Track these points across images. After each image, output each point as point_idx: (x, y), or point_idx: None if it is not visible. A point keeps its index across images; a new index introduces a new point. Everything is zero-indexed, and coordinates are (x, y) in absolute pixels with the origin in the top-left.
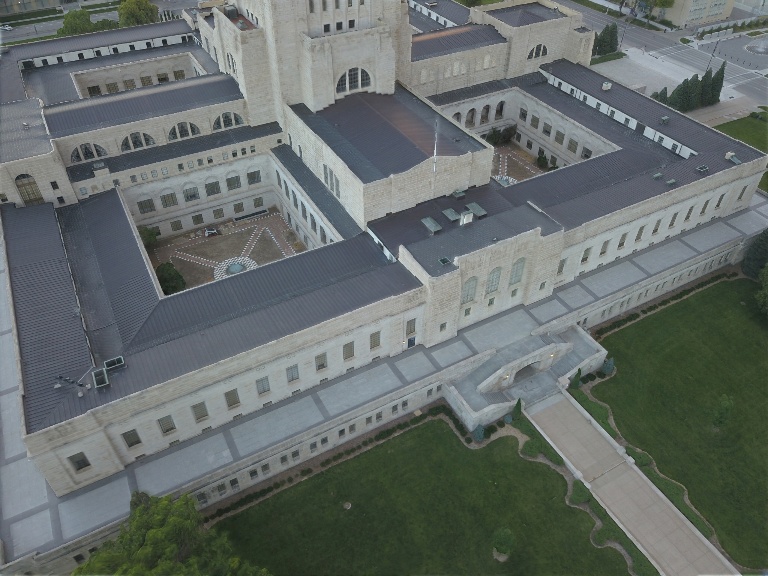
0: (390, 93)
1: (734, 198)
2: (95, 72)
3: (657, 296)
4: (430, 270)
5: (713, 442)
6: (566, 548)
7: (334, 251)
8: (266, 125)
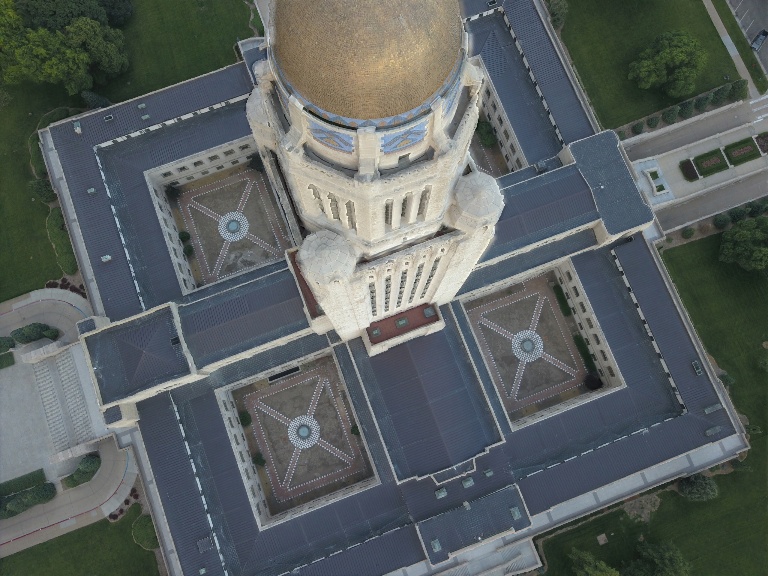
0: None
1: None
2: (604, 393)
3: None
4: None
5: (208, 2)
6: None
7: None
8: None
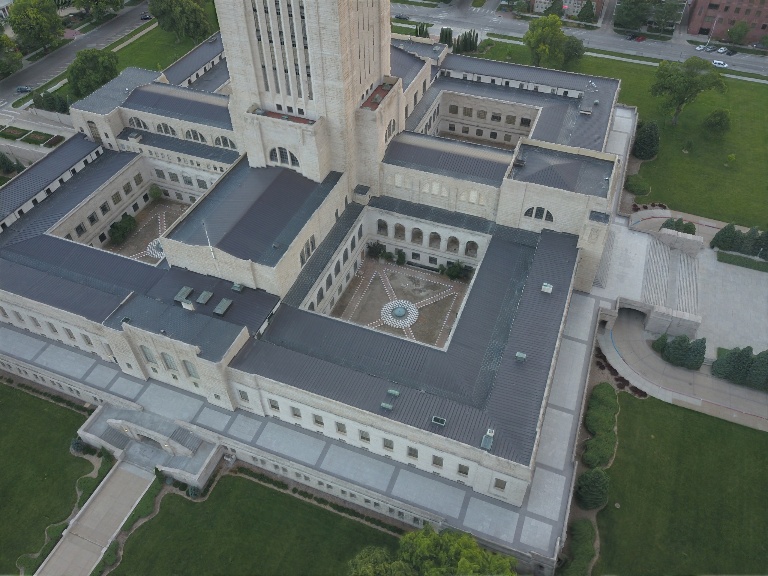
0: (316, 181)
1: (483, 480)
2: None
3: (326, 491)
4: (111, 319)
5: None
6: (7, 544)
7: (141, 270)
8: None
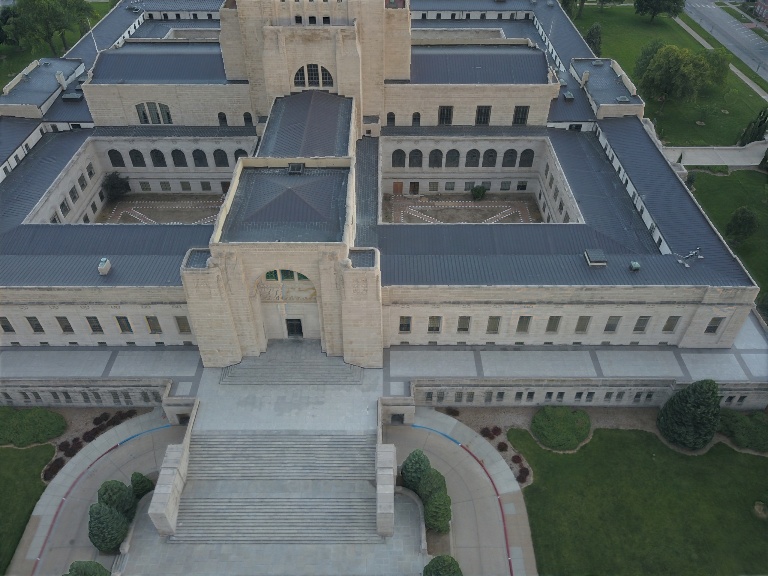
0: None
1: None
2: None
3: None
4: (49, 60)
5: None
6: None
7: None
8: None
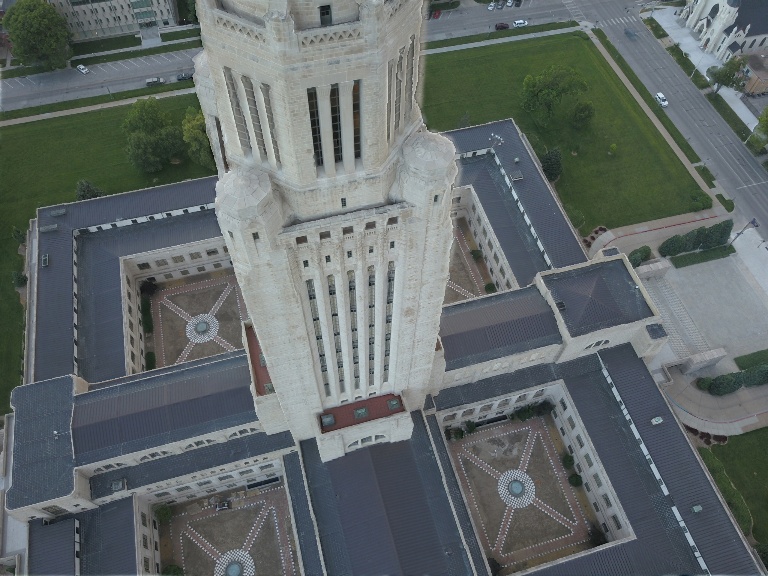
0: (406, 439)
1: None
2: (144, 256)
3: None
4: None
5: None
6: None
7: None
8: (282, 433)
